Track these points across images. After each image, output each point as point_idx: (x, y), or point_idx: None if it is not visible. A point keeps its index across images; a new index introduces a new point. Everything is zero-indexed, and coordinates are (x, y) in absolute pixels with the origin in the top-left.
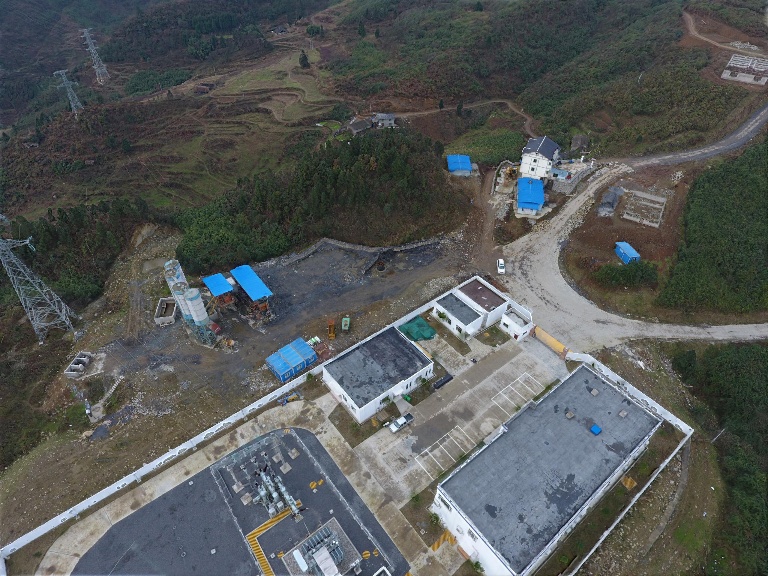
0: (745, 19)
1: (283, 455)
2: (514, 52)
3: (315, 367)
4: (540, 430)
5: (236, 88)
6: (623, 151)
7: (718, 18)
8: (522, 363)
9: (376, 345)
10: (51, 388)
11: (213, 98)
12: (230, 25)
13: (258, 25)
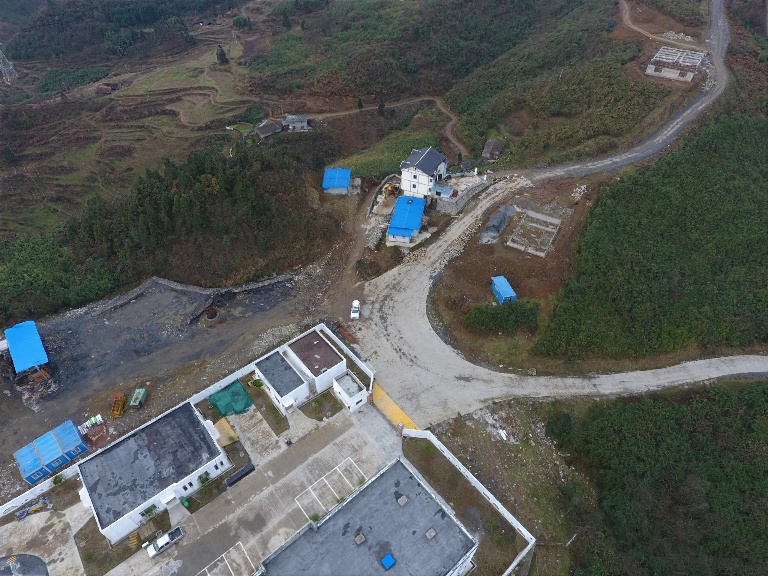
0: (680, 7)
1: None
2: (444, 45)
3: (76, 463)
4: (314, 565)
5: (143, 88)
6: (532, 159)
7: (653, 6)
8: (348, 444)
9: (159, 430)
10: None
11: (114, 100)
12: (152, 17)
13: (185, 17)
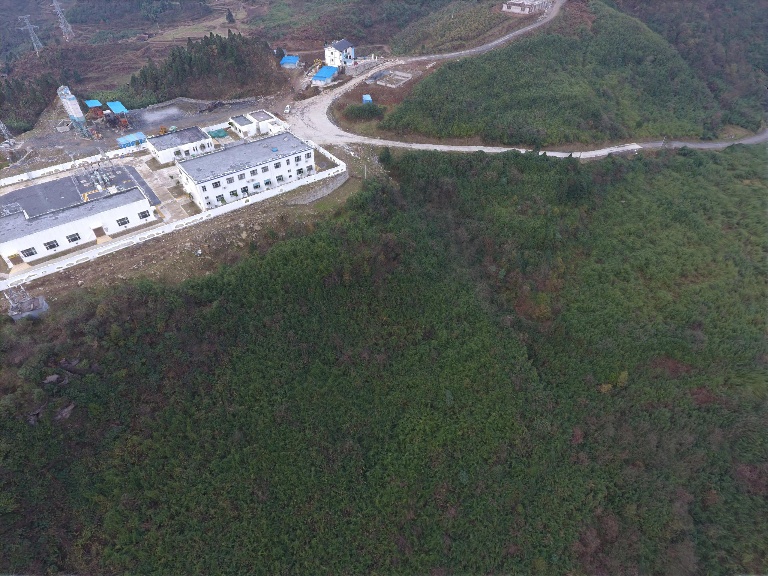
0: None
1: (113, 173)
2: (392, 7)
3: (144, 143)
4: (245, 150)
5: (171, 37)
6: None
7: None
8: None
9: (183, 133)
10: None
11: (150, 43)
12: None
13: None
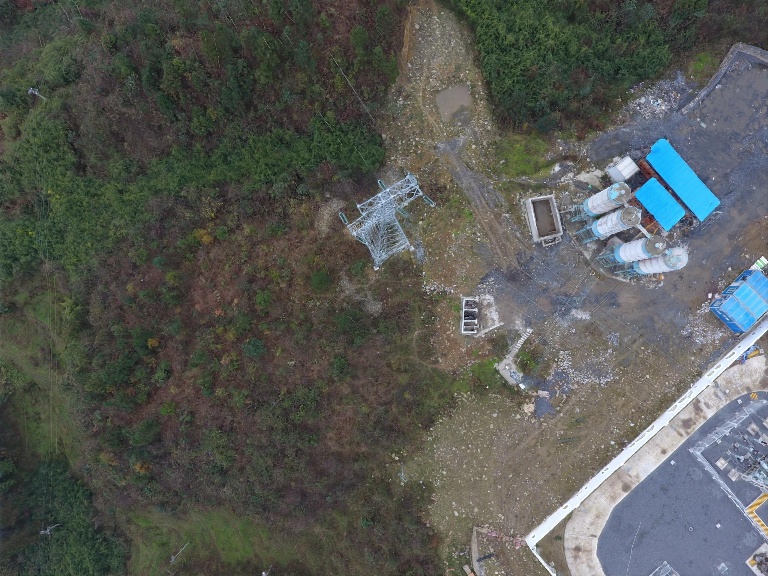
0: None
1: (757, 425)
2: None
3: None
4: None
5: None
6: None
7: None
8: None
9: None
10: (440, 343)
11: None
12: None
13: None
